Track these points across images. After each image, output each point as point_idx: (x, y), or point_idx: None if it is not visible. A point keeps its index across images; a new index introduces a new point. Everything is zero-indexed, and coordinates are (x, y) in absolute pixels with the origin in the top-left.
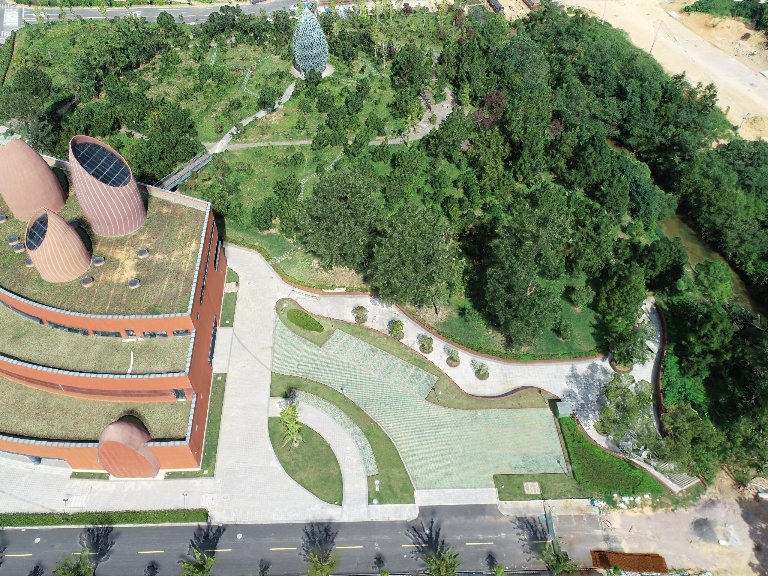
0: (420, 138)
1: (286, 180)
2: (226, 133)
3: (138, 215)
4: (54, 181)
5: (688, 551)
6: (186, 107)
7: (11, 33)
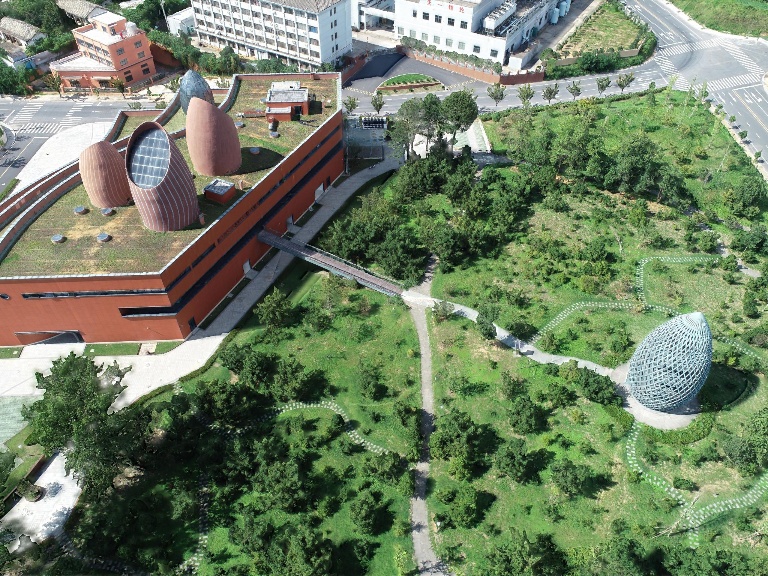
0: None
1: None
2: (452, 301)
3: (151, 220)
4: (209, 152)
5: None
6: (515, 252)
7: None
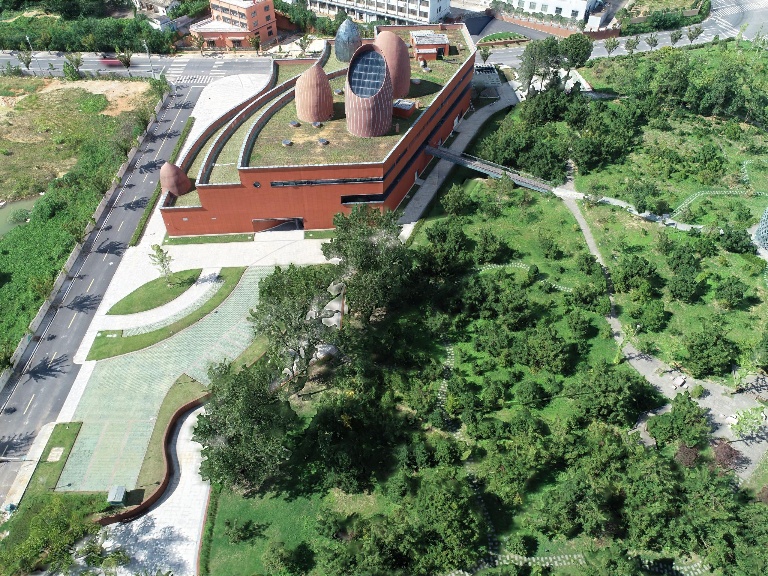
0: (645, 377)
1: (489, 236)
2: None
3: (361, 127)
4: (392, 78)
5: None
6: (637, 159)
7: (727, 38)
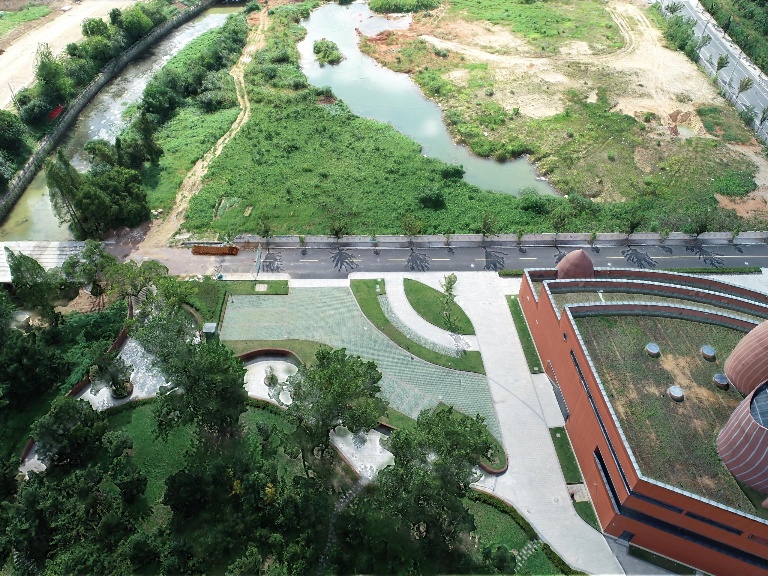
0: None
1: None
2: None
3: None
4: None
5: (172, 256)
6: None
7: None
